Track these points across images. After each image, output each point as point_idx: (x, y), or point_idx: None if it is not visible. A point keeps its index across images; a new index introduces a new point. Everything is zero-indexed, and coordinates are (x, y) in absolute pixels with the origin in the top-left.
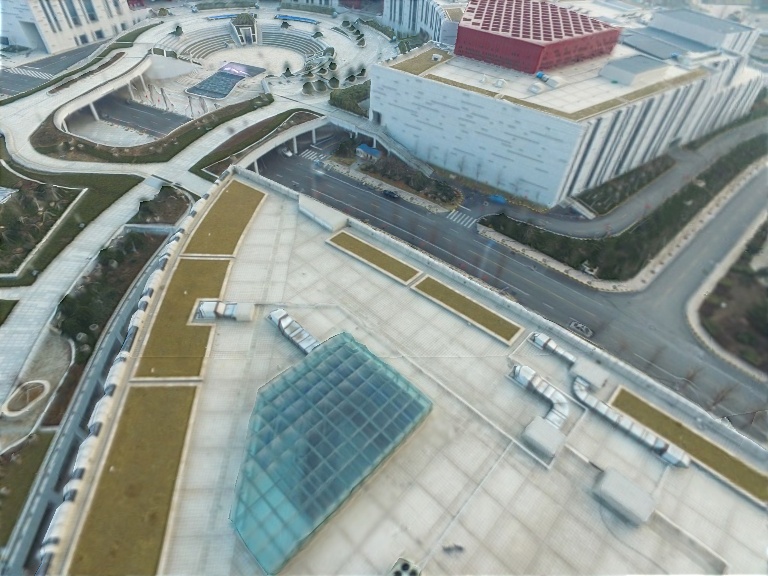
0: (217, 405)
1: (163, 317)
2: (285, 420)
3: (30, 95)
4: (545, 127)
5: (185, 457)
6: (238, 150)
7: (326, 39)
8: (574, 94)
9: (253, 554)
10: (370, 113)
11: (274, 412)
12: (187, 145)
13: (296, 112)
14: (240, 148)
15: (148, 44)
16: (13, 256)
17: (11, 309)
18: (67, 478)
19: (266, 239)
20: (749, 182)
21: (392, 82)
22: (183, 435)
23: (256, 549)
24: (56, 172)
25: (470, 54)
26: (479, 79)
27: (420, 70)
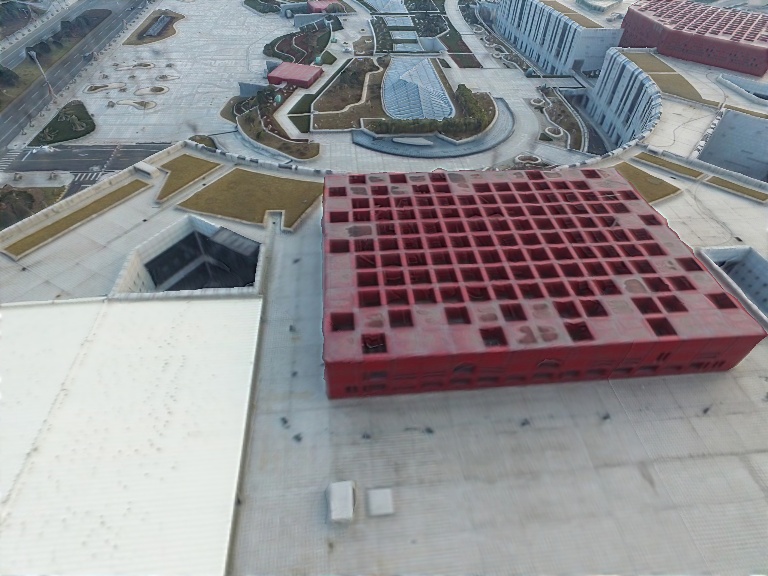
0: (564, 3)
1: None
2: None
3: None
4: None
5: None
6: None
7: None
8: None
9: (600, 6)
10: None
11: None
12: None
13: None
14: None
15: None
16: None
17: None
18: None
19: None
20: None
21: None
22: (562, 4)
23: (600, 5)
24: None
25: None
26: None
27: None
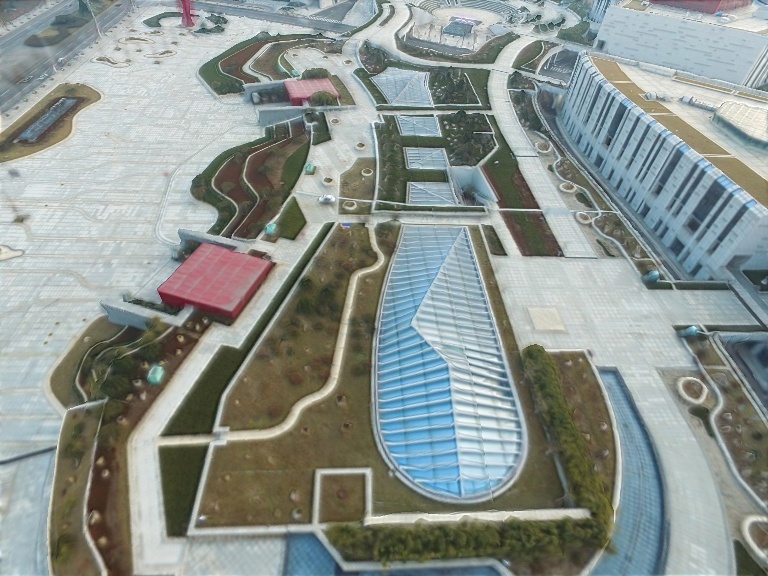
0: None
1: (631, 98)
2: (737, 118)
3: (368, 27)
4: (742, 40)
5: None
6: (533, 58)
7: (512, 2)
8: (748, 24)
9: (767, 142)
10: (595, 42)
11: (730, 116)
12: (497, 55)
13: (543, 42)
14: (533, 57)
15: (399, 1)
16: None
17: (494, 118)
18: None
19: (639, 78)
20: None
21: (623, 17)
22: (691, 126)
23: None
24: (435, 66)
25: (664, 2)
26: (682, 16)
27: (641, 10)
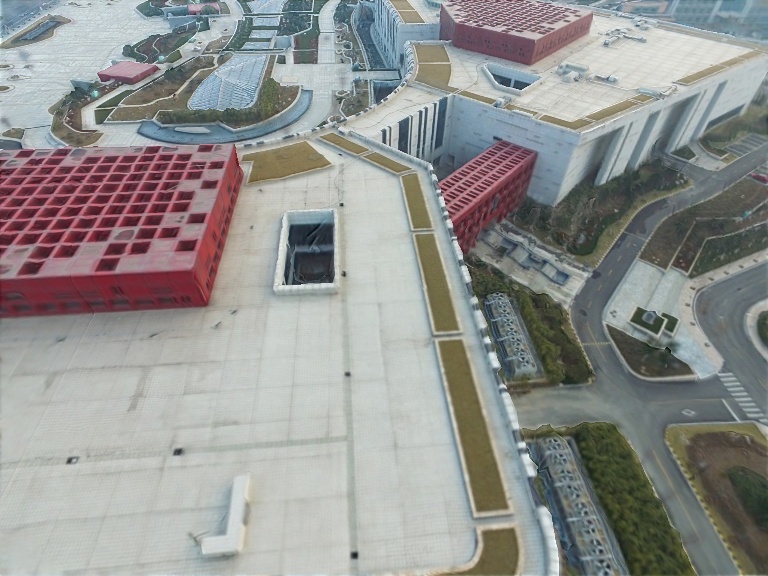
0: None
1: None
2: None
3: None
4: None
5: (410, 3)
6: None
7: None
8: None
9: (436, 2)
10: None
11: None
12: None
13: None
14: None
15: None
16: (309, 6)
17: (318, 17)
18: None
19: None
20: (600, 3)
21: None
22: None
23: None
24: None
25: None
26: None
27: None
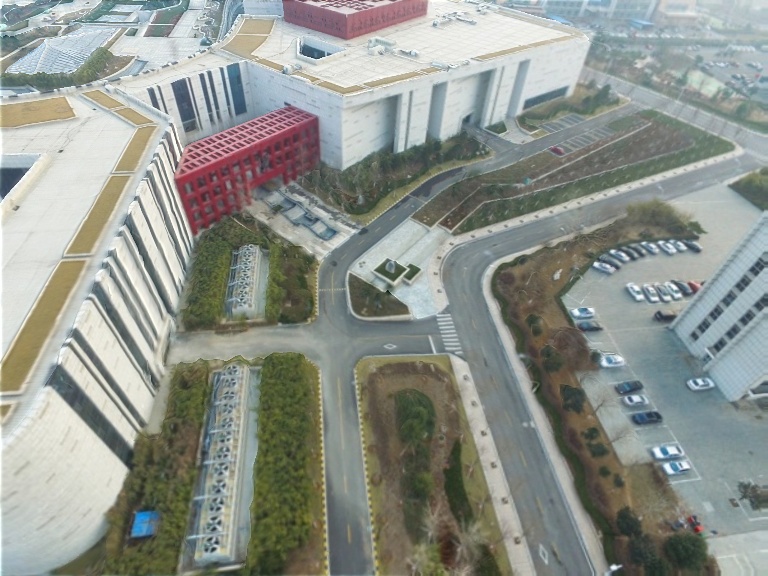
0: None
1: None
2: None
3: None
4: None
5: None
6: None
7: None
8: None
9: None
10: None
11: None
12: None
13: None
14: None
15: None
16: None
17: None
18: (228, 23)
19: None
20: None
21: None
22: None
23: None
24: None
25: None
26: None
27: None
